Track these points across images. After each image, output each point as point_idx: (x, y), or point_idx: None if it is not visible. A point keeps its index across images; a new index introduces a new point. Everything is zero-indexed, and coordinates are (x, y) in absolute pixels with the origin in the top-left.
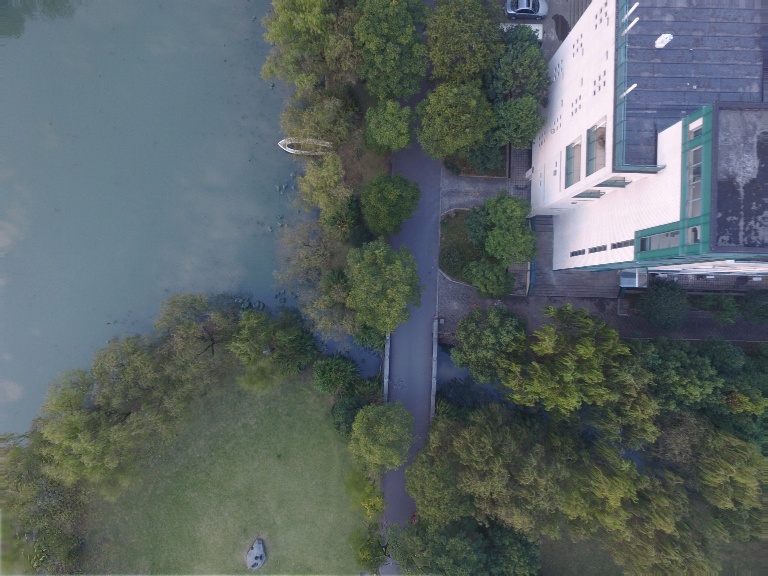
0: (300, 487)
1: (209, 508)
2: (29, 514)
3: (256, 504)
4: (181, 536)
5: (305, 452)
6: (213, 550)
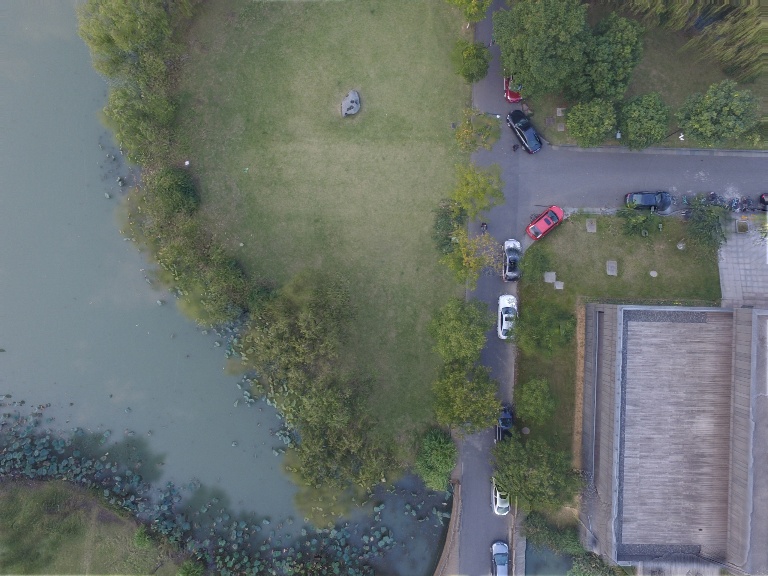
0: (393, 41)
1: (303, 63)
2: (123, 82)
3: (350, 58)
4: (276, 91)
5: (398, 7)
6: (307, 103)
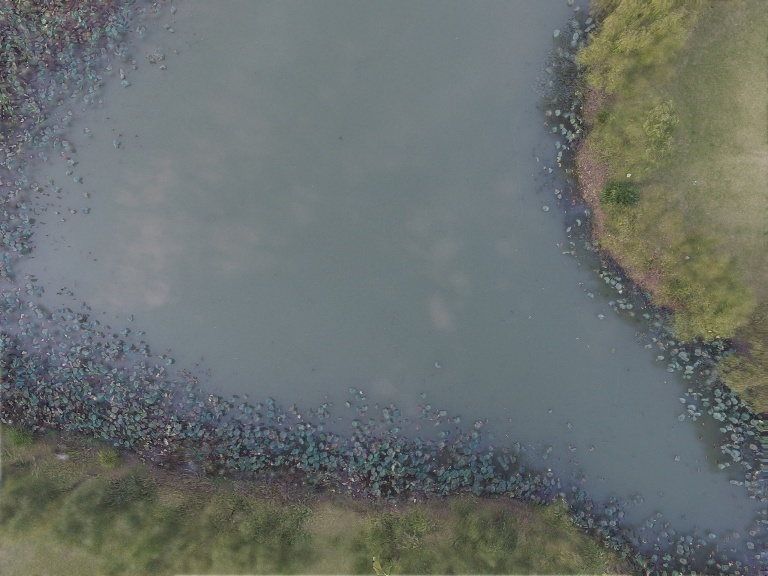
0: None
1: (750, 74)
2: (558, 93)
3: None
4: (722, 103)
5: None
6: (755, 115)
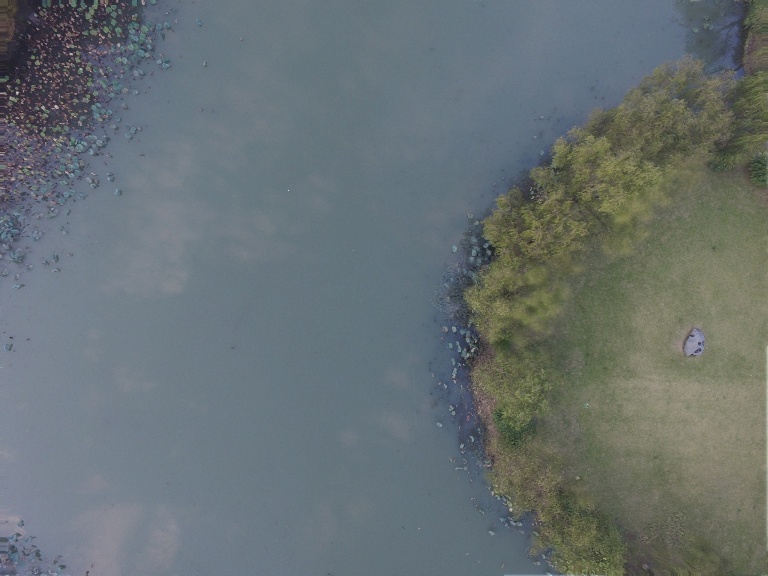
0: (734, 278)
1: (645, 298)
2: (455, 308)
3: (691, 295)
4: (616, 326)
5: (739, 244)
6: (649, 340)
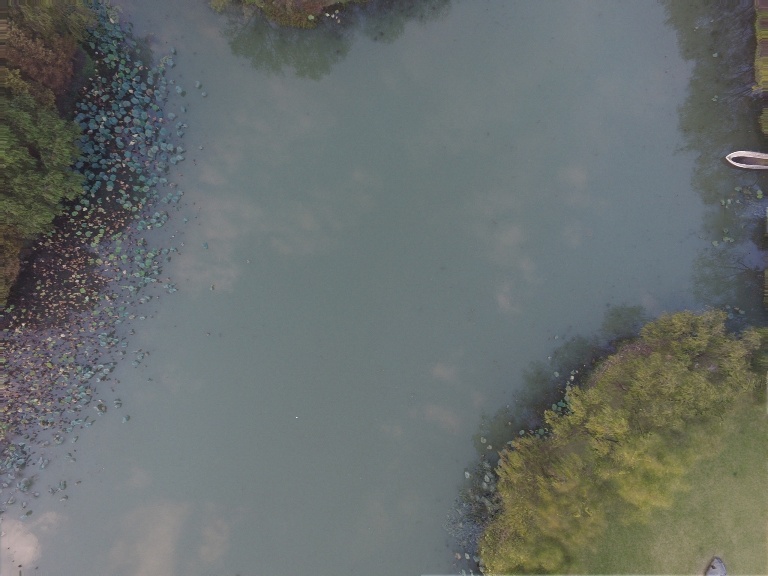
0: (757, 505)
1: (664, 527)
2: (468, 534)
3: (712, 522)
4: (634, 555)
5: (762, 470)
6: (668, 569)
